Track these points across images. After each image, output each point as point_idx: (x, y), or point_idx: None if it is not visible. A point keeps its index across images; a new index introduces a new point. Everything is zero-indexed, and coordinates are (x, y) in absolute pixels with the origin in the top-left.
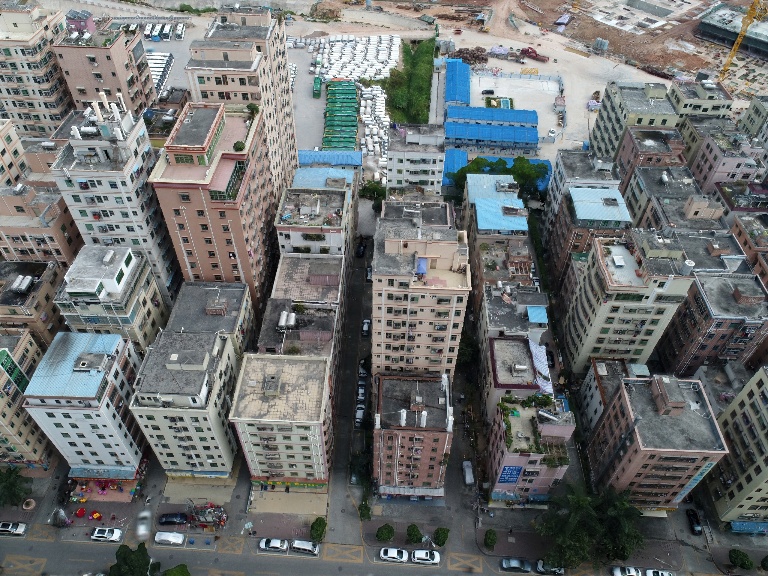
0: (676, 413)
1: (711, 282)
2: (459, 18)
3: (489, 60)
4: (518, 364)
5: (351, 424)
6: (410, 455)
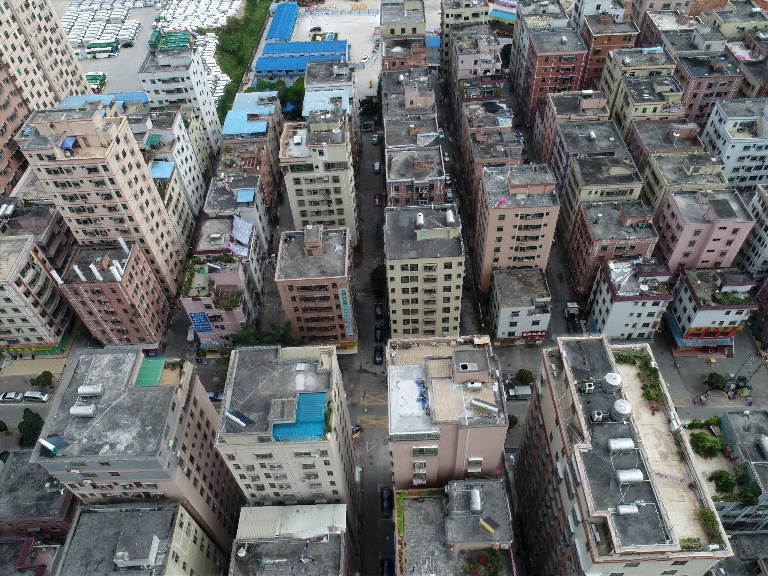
0: (318, 253)
1: (400, 155)
2: None
3: (326, 1)
4: None
5: None
6: (105, 309)
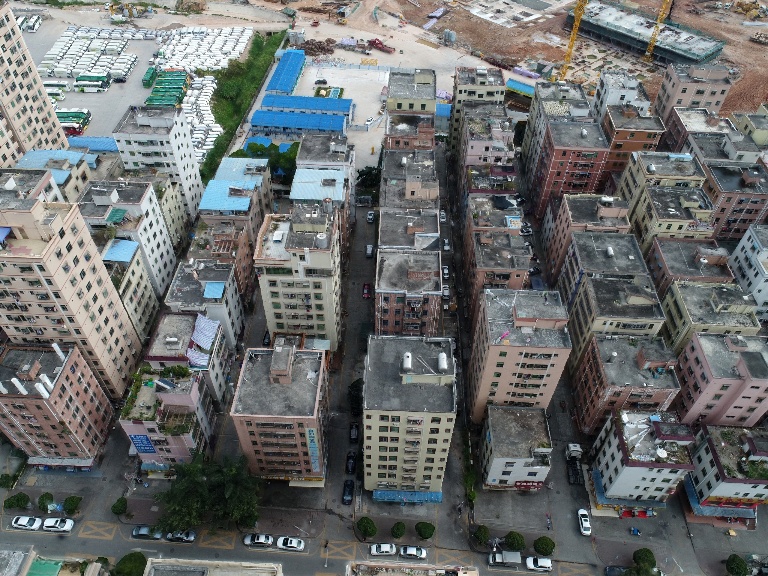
0: (286, 381)
1: (393, 258)
2: (323, 11)
3: (336, 51)
4: (173, 337)
5: None
6: (30, 424)
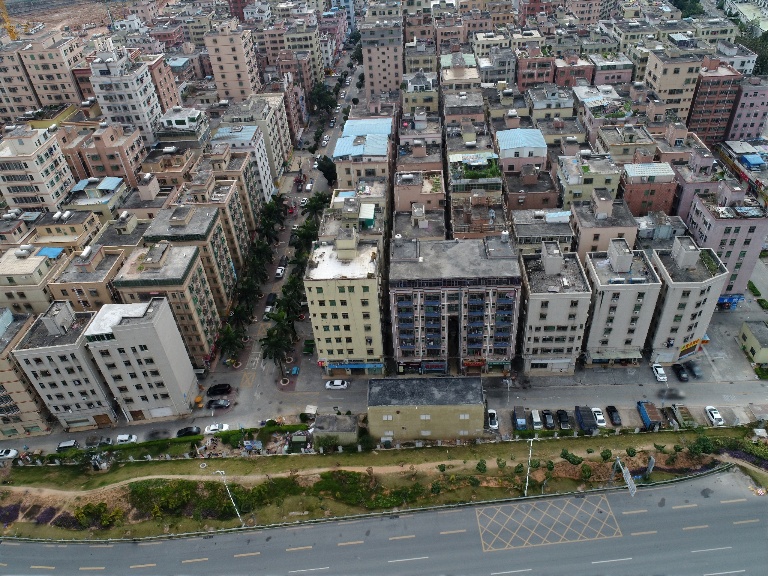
0: None
1: None
2: None
3: None
4: None
5: None
6: None
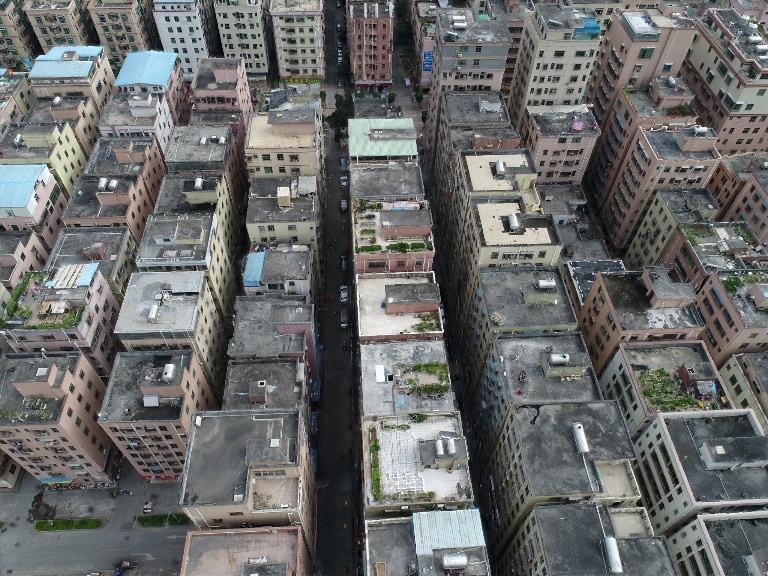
0: (516, 11)
1: None
2: None
3: None
4: None
5: (335, 66)
6: (371, 44)
